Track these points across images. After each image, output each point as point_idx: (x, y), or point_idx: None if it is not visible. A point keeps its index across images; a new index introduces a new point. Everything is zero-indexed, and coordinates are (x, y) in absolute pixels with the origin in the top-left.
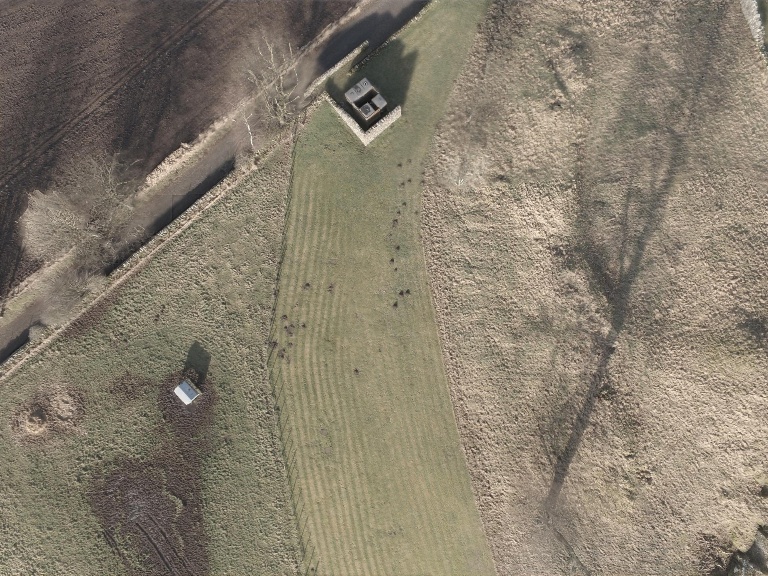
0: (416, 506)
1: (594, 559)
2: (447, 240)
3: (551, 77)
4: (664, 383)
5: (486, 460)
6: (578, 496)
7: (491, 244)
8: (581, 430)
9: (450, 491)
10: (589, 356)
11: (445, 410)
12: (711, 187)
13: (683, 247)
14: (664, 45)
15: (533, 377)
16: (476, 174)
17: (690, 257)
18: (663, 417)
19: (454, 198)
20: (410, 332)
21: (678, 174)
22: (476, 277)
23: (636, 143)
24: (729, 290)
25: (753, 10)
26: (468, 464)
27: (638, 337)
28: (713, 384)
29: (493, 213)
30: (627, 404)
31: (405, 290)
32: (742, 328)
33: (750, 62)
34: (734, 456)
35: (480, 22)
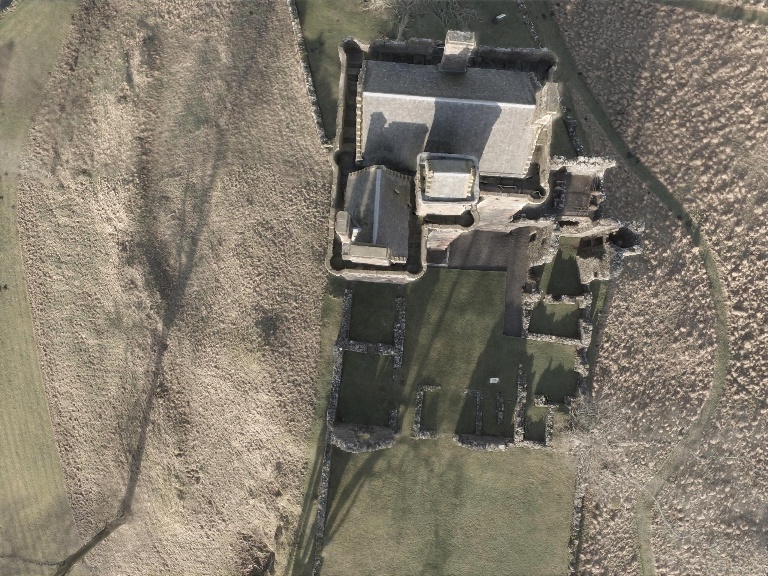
0: (14, 504)
1: (163, 559)
2: (42, 235)
3: (124, 70)
4: (205, 381)
5: (78, 458)
6: (148, 495)
7: (77, 239)
8: (145, 428)
9: (45, 489)
10: (149, 353)
11: (41, 407)
12: (244, 182)
13: (222, 243)
14: (220, 38)
15: (113, 374)
16: (64, 168)
17: (227, 253)
18: (207, 415)
19: (47, 192)
20: (8, 328)
21: (219, 169)
22: (65, 272)
23: (194, 137)
24: (254, 287)
25: (287, 3)
26: (62, 462)
27: (186, 334)
28: (236, 382)
29: (79, 207)
30: (178, 402)
31: (3, 285)
32: (257, 325)
33: (290, 56)
34: (254, 455)
35: (74, 13)
